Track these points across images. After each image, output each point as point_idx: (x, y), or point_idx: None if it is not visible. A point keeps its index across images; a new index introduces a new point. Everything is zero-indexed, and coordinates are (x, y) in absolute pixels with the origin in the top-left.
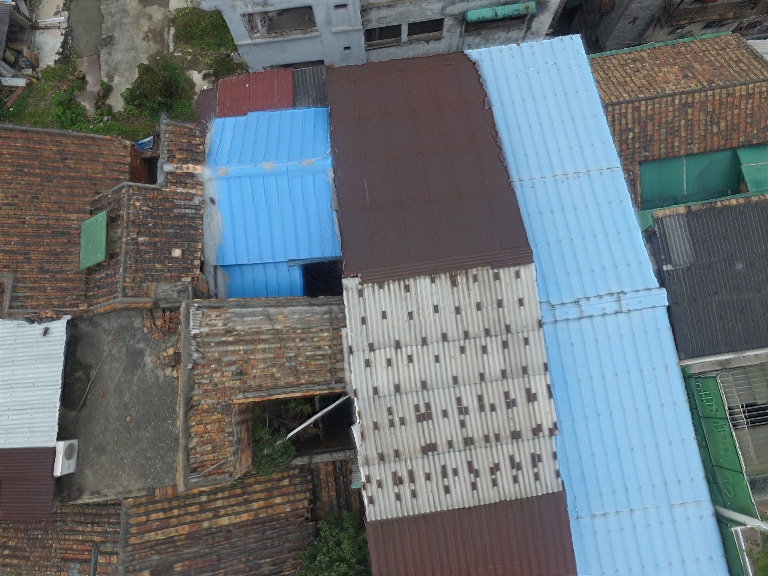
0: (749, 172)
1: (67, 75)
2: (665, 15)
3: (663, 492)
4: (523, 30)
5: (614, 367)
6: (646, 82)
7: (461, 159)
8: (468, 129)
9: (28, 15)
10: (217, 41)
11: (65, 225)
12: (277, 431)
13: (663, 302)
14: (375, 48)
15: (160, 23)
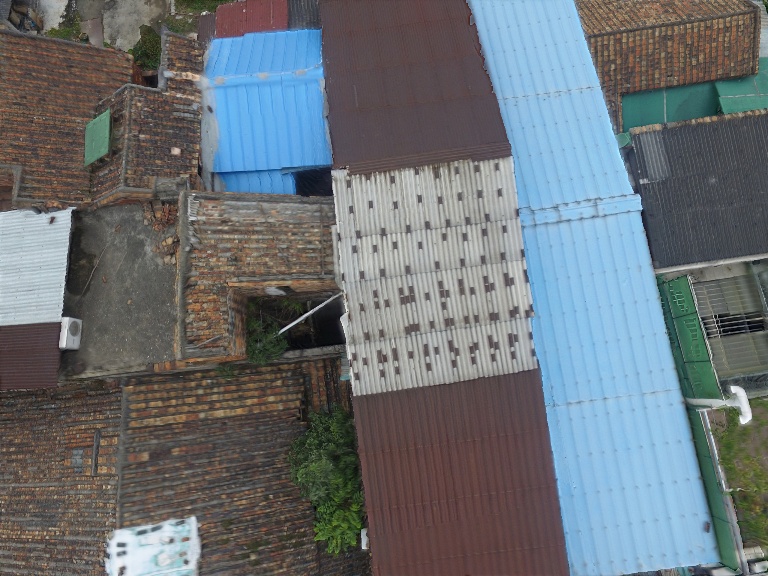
0: (726, 103)
1: (71, 37)
2: None
3: (635, 382)
4: None
5: (590, 267)
6: (628, 17)
7: (446, 68)
8: (453, 42)
9: None
10: (217, 4)
11: (71, 127)
12: (270, 325)
13: (637, 207)
14: None
15: None
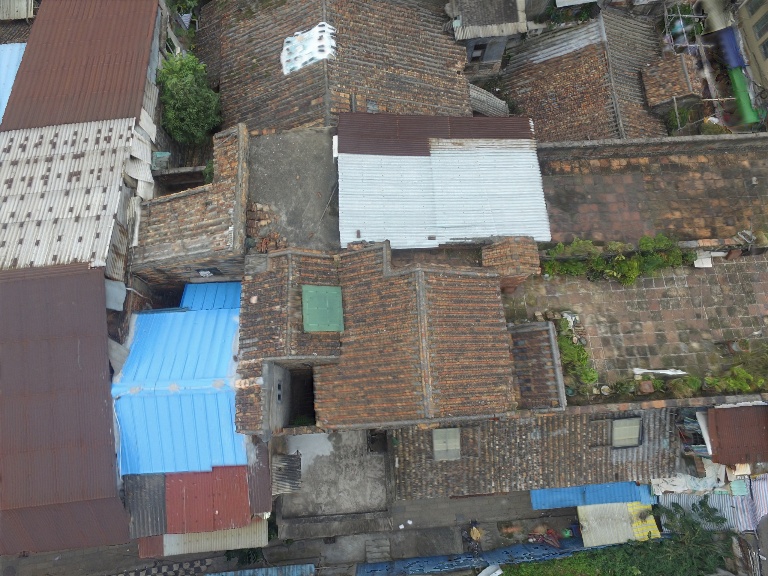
0: None
1: None
2: None
3: None
4: None
5: None
6: None
7: None
8: None
9: None
10: None
11: None
12: None
13: None
14: None
15: None
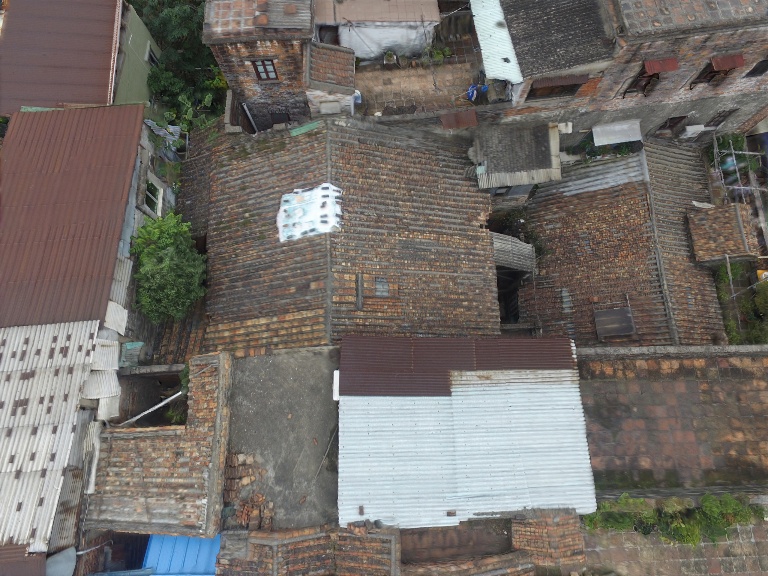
0: None
1: None
2: None
3: None
4: None
5: None
6: None
7: None
8: None
9: None
10: None
11: None
12: None
13: None
14: None
15: None
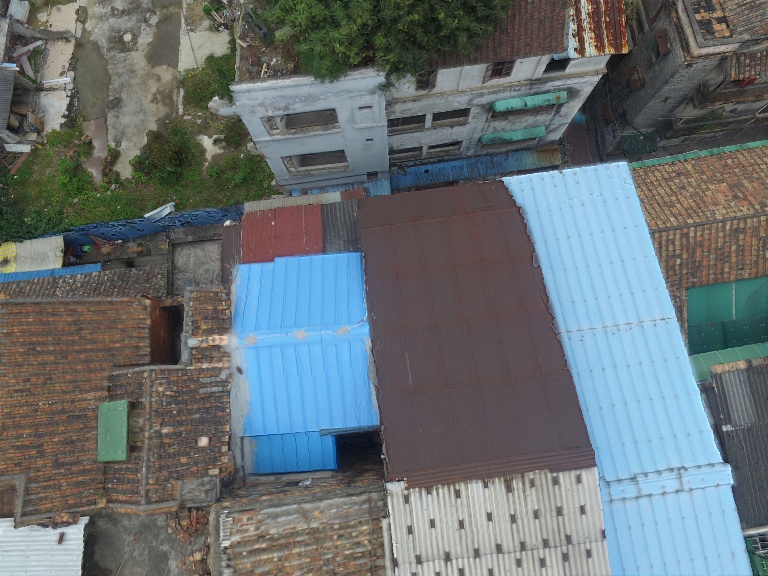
0: None
1: (73, 140)
2: (699, 96)
3: None
4: (551, 114)
5: (676, 553)
6: (694, 203)
7: (510, 330)
8: (516, 292)
9: (33, 76)
10: None
11: (81, 407)
12: None
13: (728, 480)
14: (397, 134)
15: (169, 84)
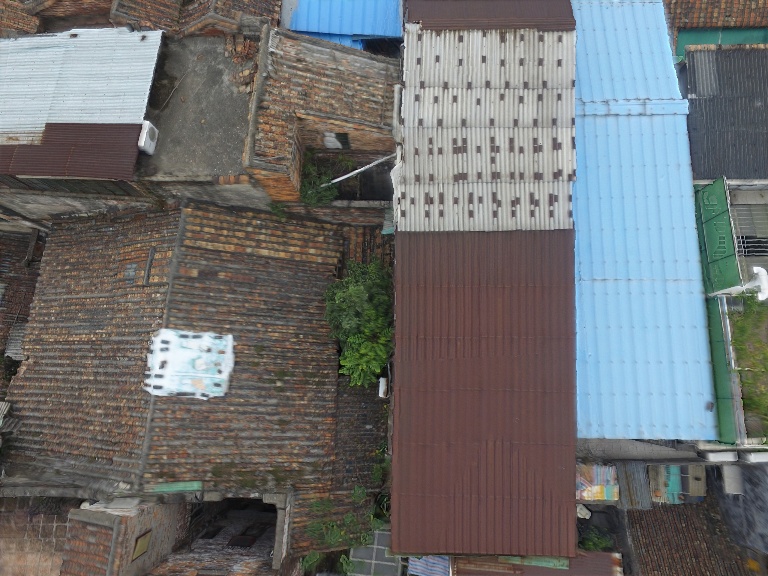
0: None
1: None
2: None
3: (660, 269)
4: None
5: (631, 160)
6: None
7: None
8: None
9: None
10: None
11: None
12: None
13: (684, 111)
14: None
15: None
